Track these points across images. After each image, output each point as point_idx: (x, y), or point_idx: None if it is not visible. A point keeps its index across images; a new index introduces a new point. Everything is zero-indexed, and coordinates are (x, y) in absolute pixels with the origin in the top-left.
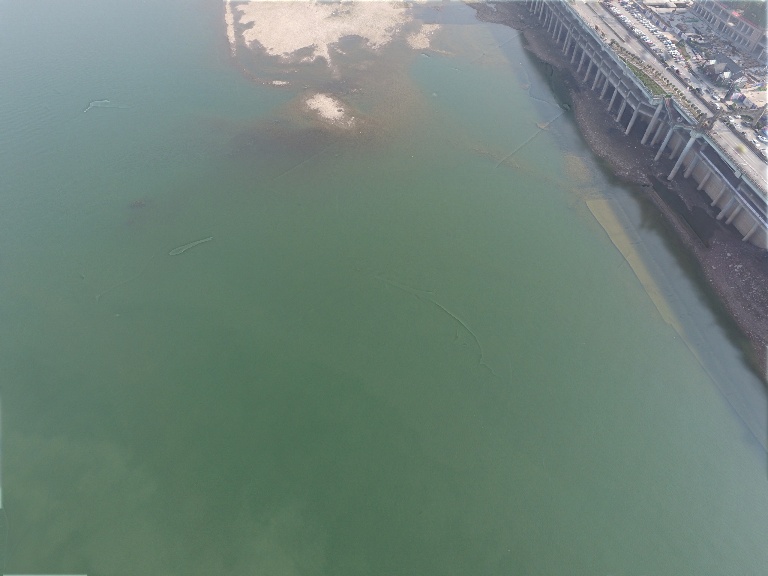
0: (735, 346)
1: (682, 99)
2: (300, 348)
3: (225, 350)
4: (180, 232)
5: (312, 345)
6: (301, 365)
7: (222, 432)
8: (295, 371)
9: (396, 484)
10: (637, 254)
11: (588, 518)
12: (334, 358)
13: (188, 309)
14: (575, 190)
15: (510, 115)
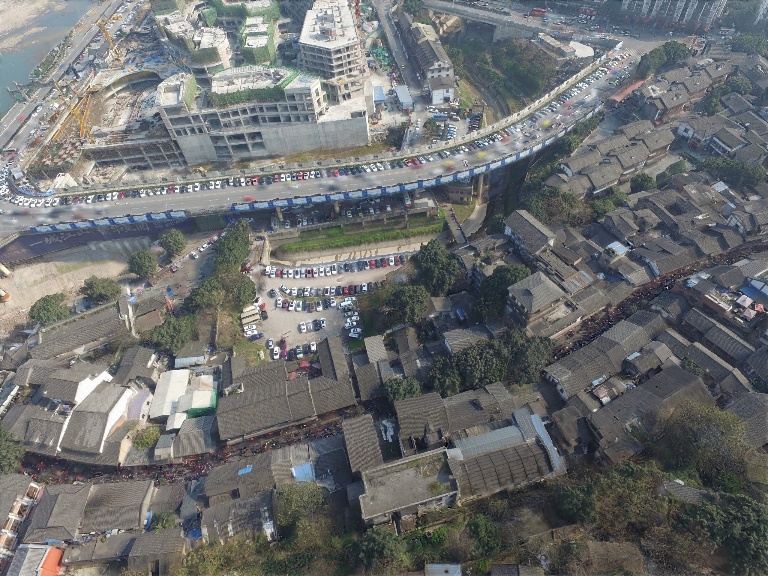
0: None
1: (44, 78)
2: None
3: None
4: None
5: None
6: None
7: None
8: None
9: None
10: None
11: None
12: None
13: None
14: None
15: (4, 99)
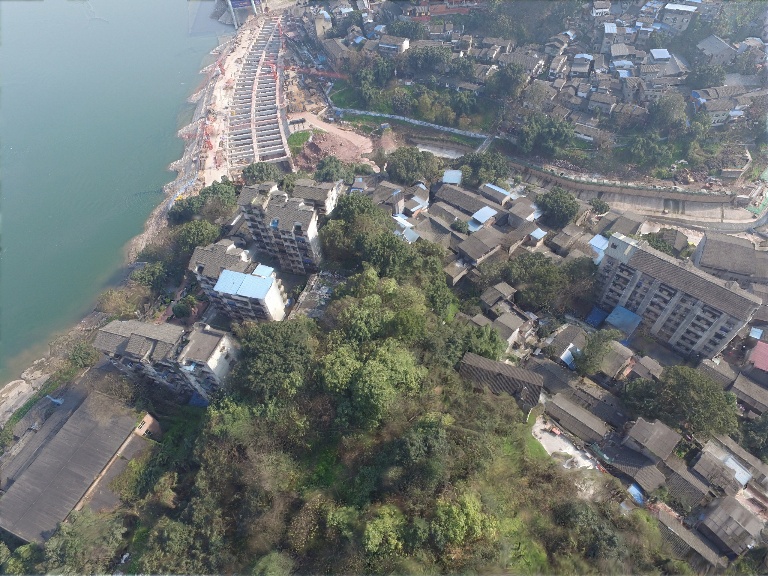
0: (207, 12)
1: None
2: (40, 29)
3: (13, 36)
4: (7, 13)
5: (45, 28)
6: (39, 33)
7: (3, 47)
8: (37, 35)
9: (58, 48)
10: None
11: None
12: (54, 31)
13: (0, 26)
14: None
15: None
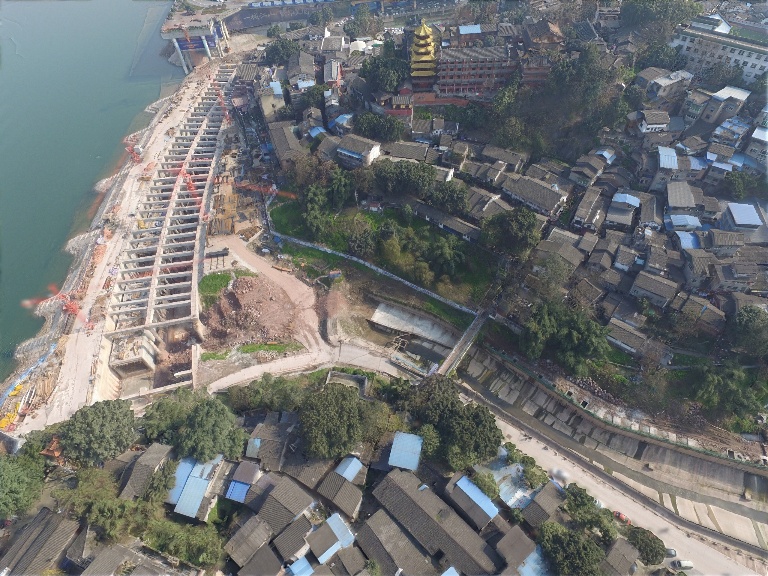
0: None
1: None
2: None
3: None
4: None
5: None
6: None
7: None
8: None
9: None
10: (152, 23)
11: (8, 64)
12: None
13: None
14: (149, 5)
15: None
